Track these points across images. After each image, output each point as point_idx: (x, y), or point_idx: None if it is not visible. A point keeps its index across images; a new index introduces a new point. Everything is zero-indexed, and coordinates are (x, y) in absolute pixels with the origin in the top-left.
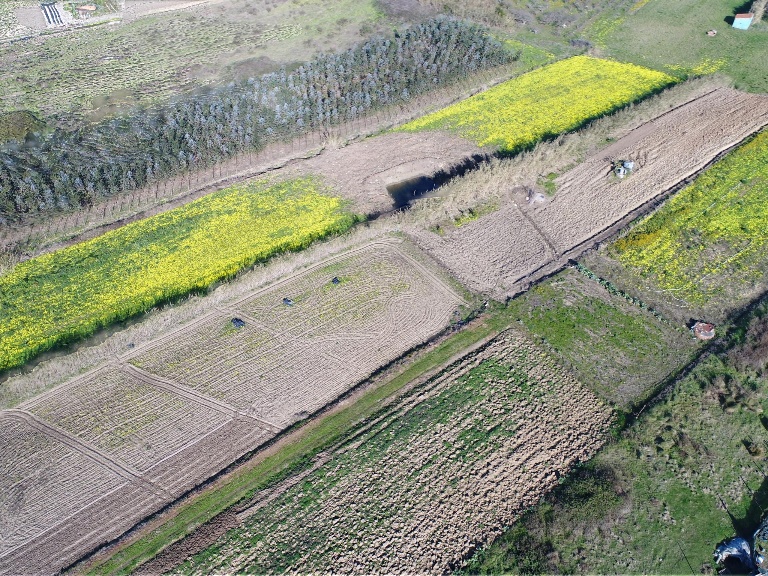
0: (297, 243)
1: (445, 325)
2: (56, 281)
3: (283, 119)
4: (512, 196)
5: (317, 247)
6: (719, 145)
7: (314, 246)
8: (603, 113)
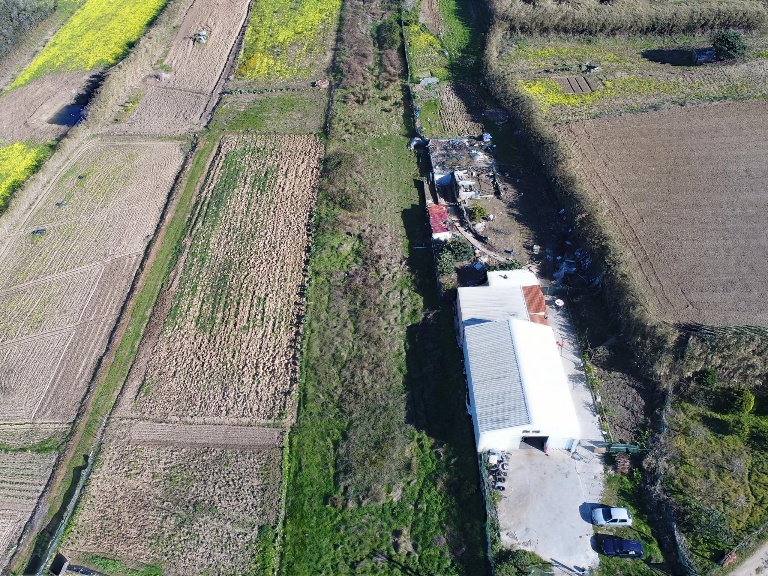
0: (23, 177)
1: (183, 157)
2: None
3: None
4: (146, 83)
5: (47, 164)
6: (245, 1)
7: (44, 164)
8: (154, 17)
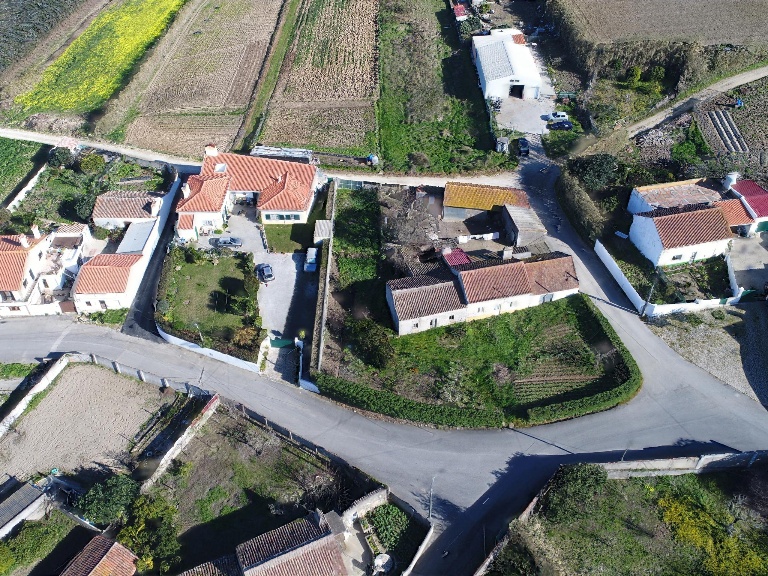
0: (177, 9)
1: None
2: (76, 69)
3: None
4: None
5: None
6: None
7: None
8: None
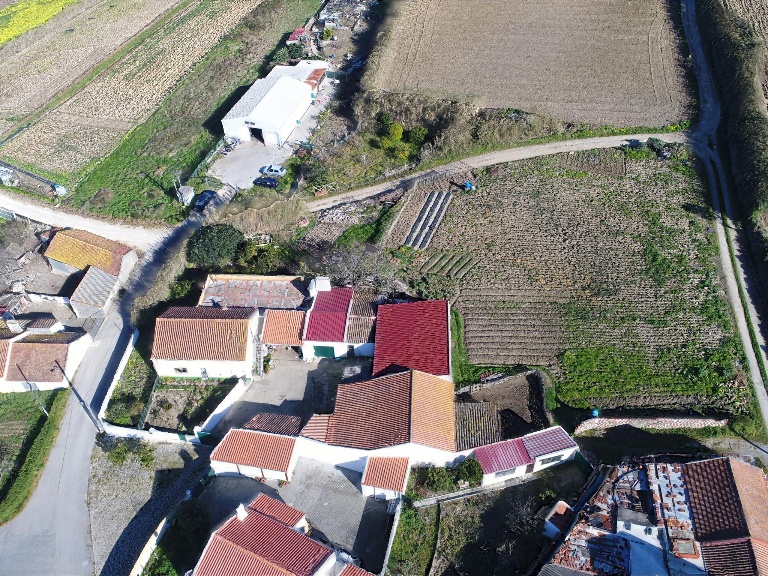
0: None
1: None
2: None
3: None
4: None
5: None
6: None
7: None
8: None
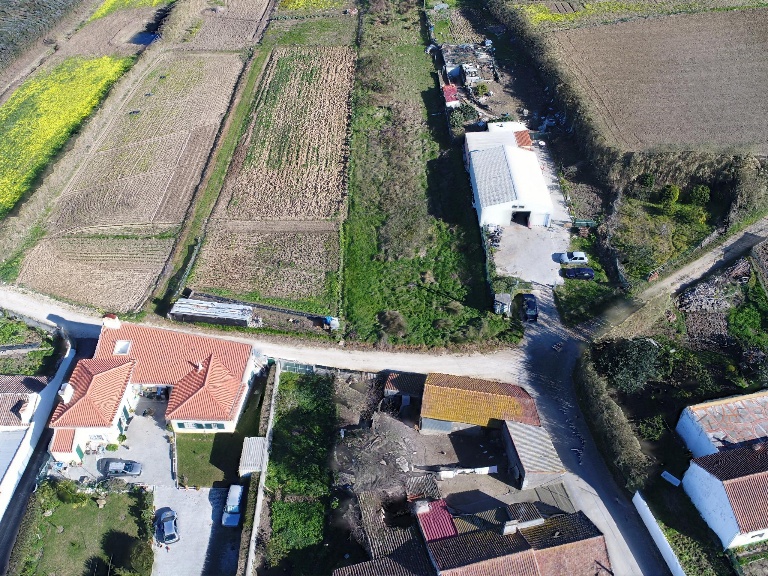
0: (115, 78)
1: (243, 63)
2: None
3: (16, 33)
4: (204, 15)
5: (135, 67)
6: None
7: (133, 67)
8: None
